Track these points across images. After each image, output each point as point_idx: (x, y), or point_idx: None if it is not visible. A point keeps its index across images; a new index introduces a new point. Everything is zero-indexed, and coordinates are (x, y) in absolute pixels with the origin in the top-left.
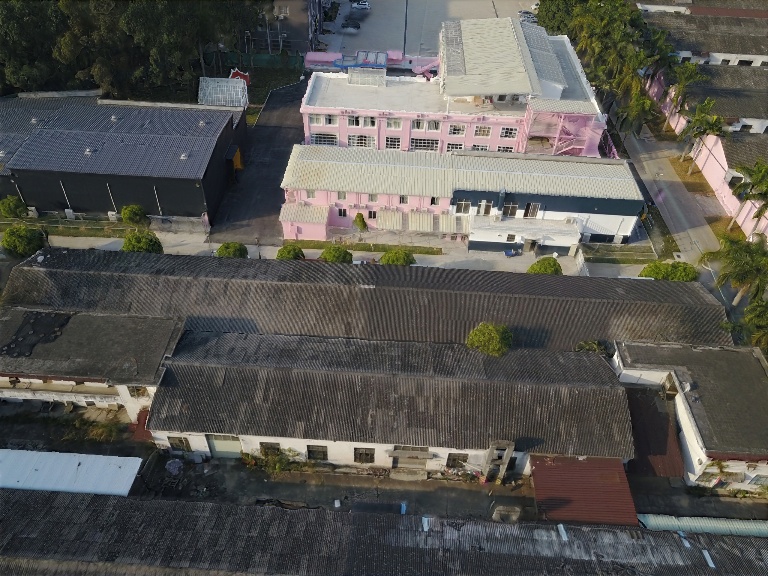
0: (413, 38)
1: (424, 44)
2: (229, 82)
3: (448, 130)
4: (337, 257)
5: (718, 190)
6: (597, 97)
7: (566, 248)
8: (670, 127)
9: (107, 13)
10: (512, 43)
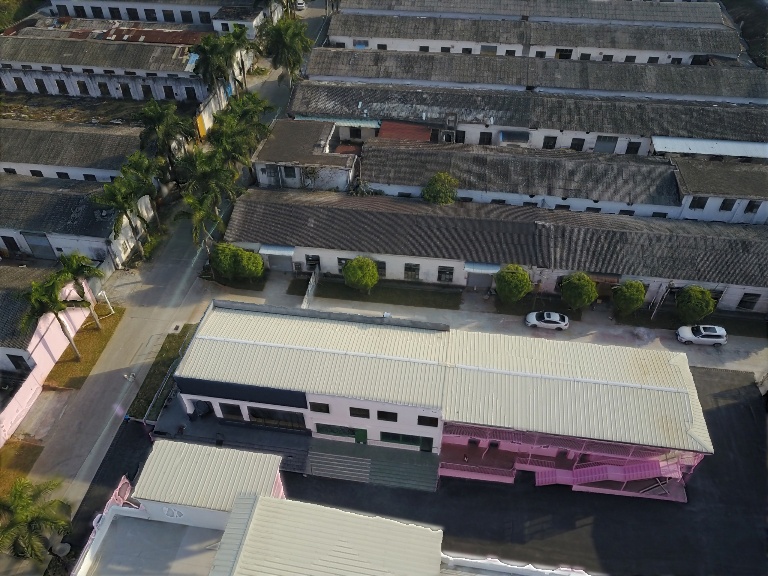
0: None
1: None
2: None
3: None
4: None
5: (6, 432)
6: None
7: None
8: None
9: None
10: None
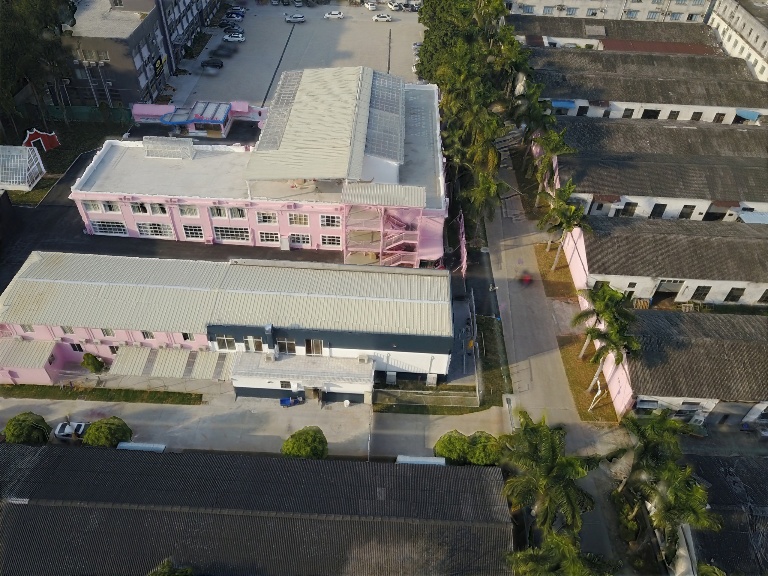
0: None
1: None
2: (11, 151)
3: (256, 218)
4: (17, 436)
5: None
6: (448, 171)
7: (359, 395)
8: (546, 201)
9: None
10: (350, 103)
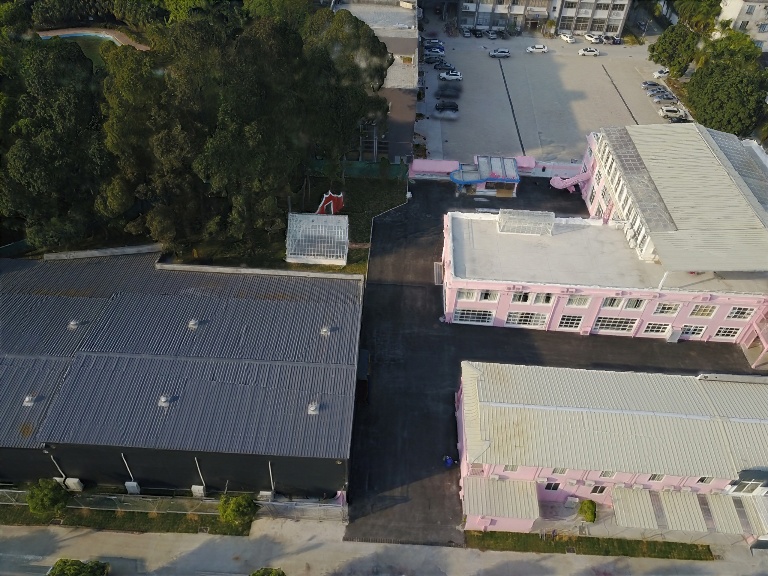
0: (526, 124)
1: (543, 133)
2: (328, 221)
3: (654, 309)
4: None
5: None
6: None
7: None
8: None
9: (179, 160)
10: (718, 170)
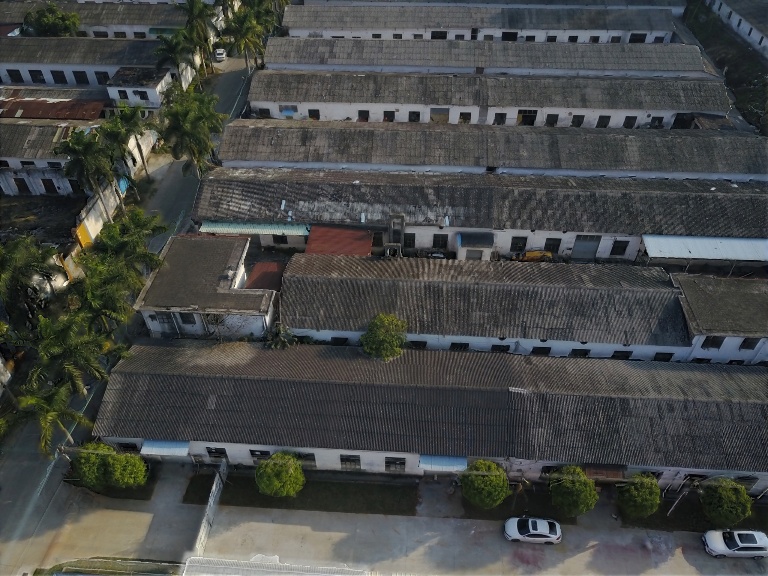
0: None
1: None
2: None
3: None
4: None
5: None
6: None
7: None
8: None
9: None
10: None
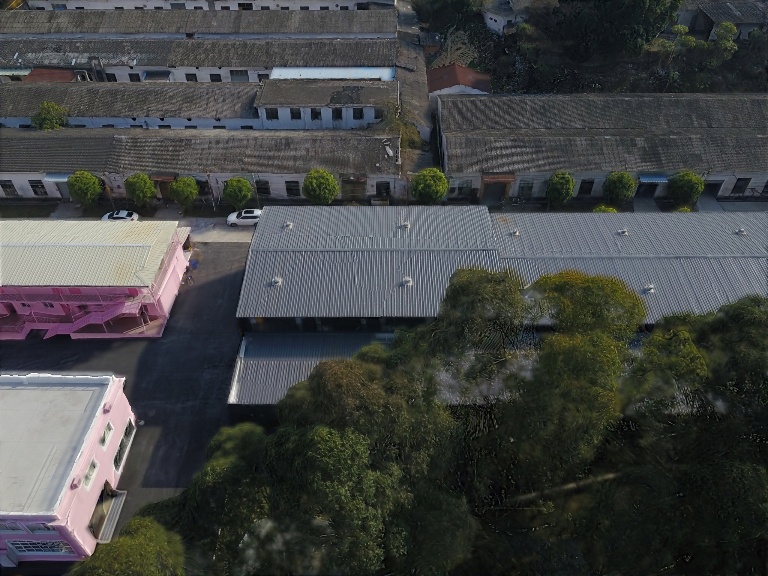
0: None
1: None
2: None
3: None
4: None
5: None
6: None
7: None
8: None
9: None
10: None
